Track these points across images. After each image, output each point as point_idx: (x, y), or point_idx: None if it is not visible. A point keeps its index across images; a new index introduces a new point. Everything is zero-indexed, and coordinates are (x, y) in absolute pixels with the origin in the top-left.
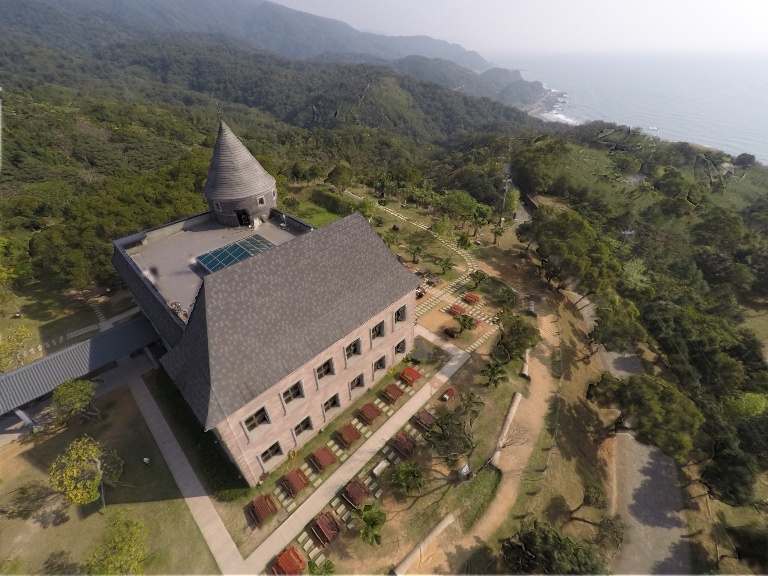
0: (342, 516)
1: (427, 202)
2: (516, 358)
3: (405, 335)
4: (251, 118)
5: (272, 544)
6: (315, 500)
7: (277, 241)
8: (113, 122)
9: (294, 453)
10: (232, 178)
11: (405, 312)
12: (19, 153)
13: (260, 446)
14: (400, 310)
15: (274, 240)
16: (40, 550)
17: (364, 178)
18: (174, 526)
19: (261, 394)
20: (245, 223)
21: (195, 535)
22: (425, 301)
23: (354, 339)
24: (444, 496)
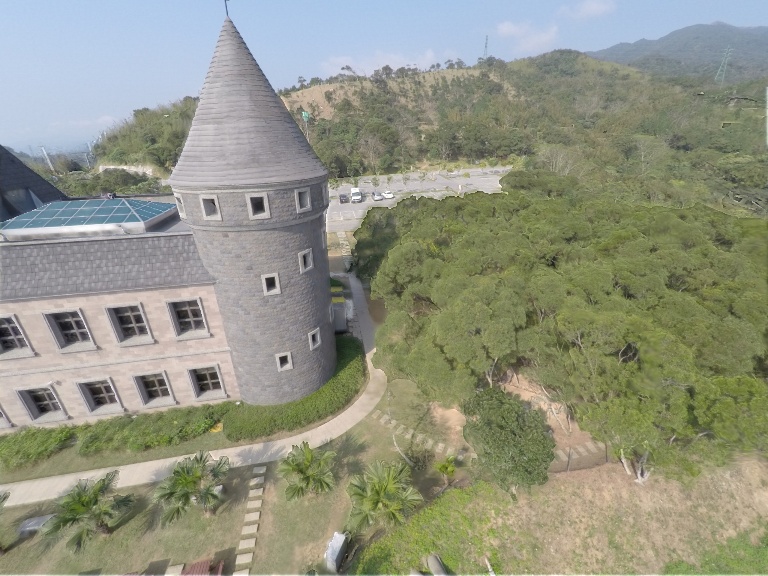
0: None
1: None
2: None
3: None
4: None
5: None
6: None
7: None
8: None
9: None
10: None
11: None
12: None
13: None
14: None
15: None
16: None
17: None
18: None
19: None
20: None
21: None
22: None
23: None
24: None
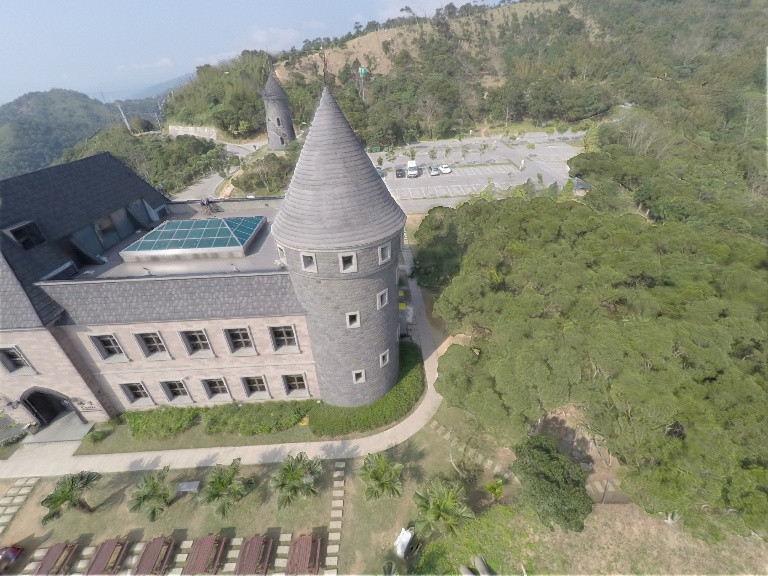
0: None
1: None
2: None
3: None
4: None
5: None
6: None
7: (215, 265)
8: None
9: None
10: None
11: None
12: None
13: None
14: None
15: (221, 264)
16: None
17: None
18: None
19: None
20: None
21: None
22: None
23: None
24: None
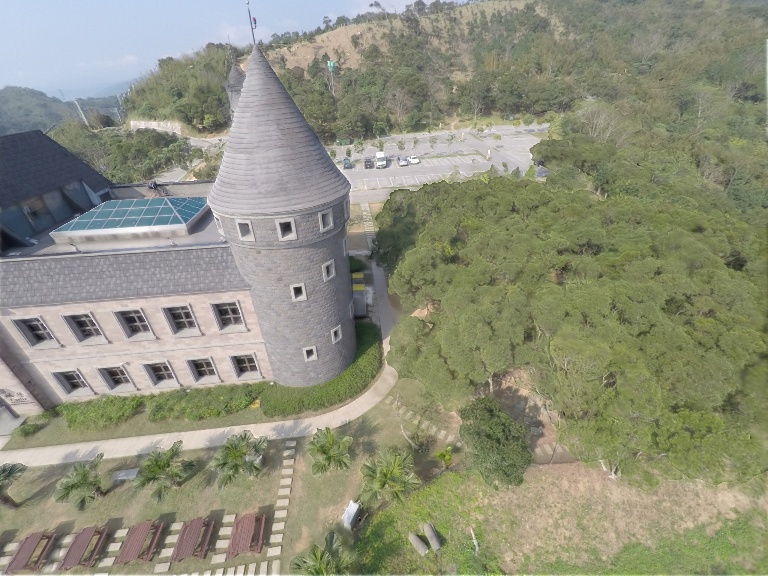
0: None
1: None
2: None
3: None
4: None
5: None
6: None
7: (155, 243)
8: None
9: None
10: None
11: None
12: None
13: None
14: None
15: (162, 242)
16: None
17: None
18: None
19: None
20: None
21: None
22: None
23: None
24: None
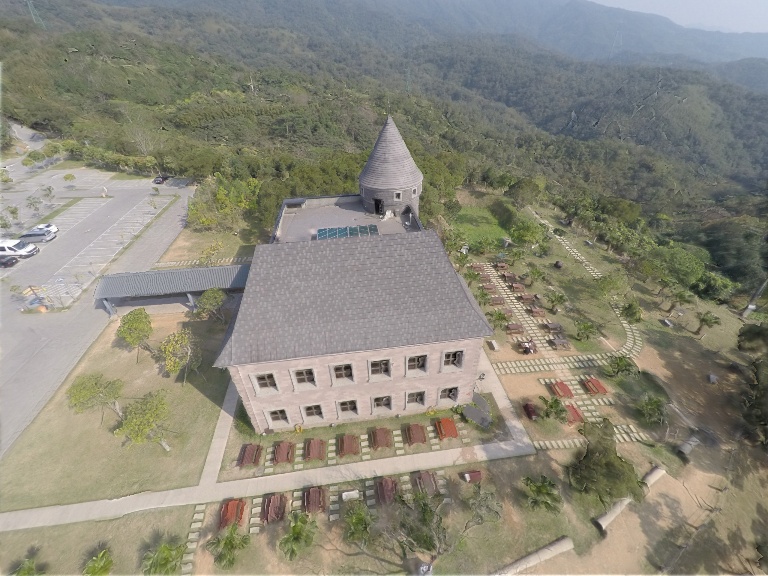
0: (294, 510)
1: (625, 247)
2: (594, 495)
3: (459, 383)
4: (501, 117)
5: (238, 487)
6: (286, 479)
7: None
8: (385, 108)
9: (301, 429)
10: (380, 169)
11: (462, 359)
12: (317, 124)
13: (267, 404)
14: (458, 354)
15: None
16: (148, 386)
17: (558, 199)
18: (204, 424)
19: (267, 361)
20: (381, 212)
21: (208, 440)
22: (529, 360)
23: (382, 358)
24: (389, 575)
